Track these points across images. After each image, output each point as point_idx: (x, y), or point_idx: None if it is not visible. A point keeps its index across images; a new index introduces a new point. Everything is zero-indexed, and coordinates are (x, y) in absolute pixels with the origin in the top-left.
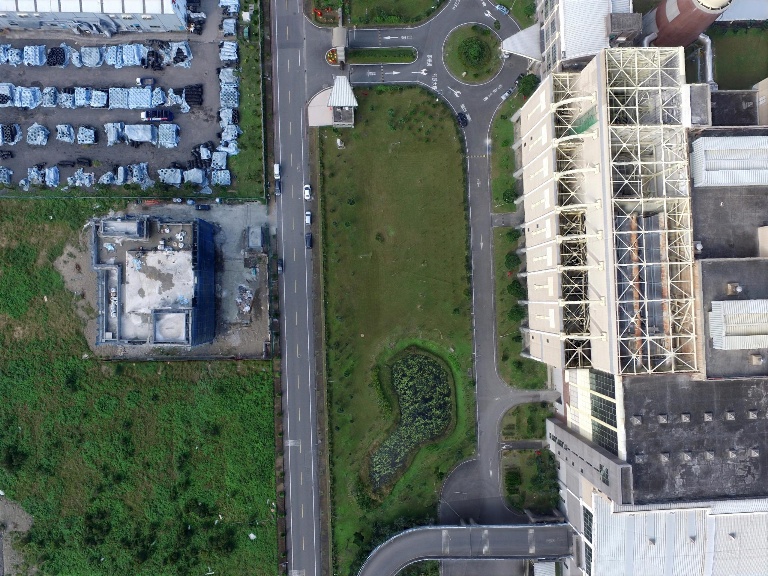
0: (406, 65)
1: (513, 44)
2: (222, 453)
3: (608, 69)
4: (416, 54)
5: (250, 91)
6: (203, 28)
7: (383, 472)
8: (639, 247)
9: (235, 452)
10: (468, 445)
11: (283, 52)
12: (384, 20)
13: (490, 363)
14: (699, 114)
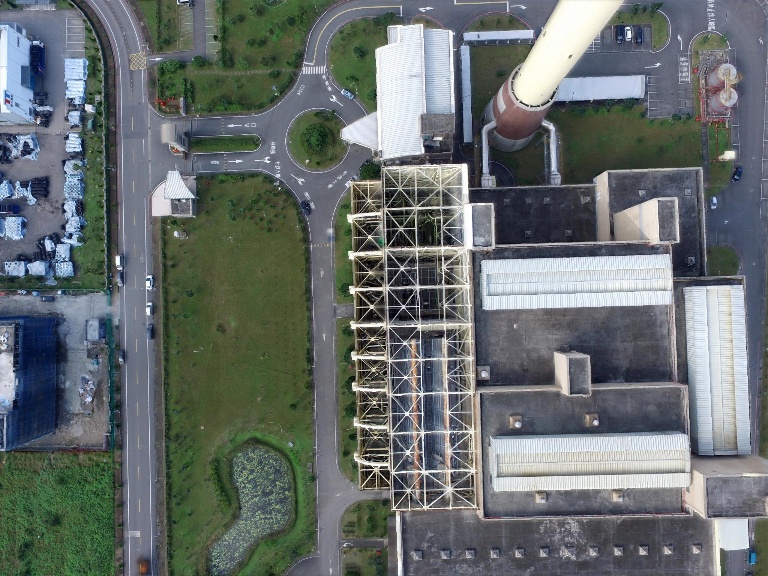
0: (249, 153)
1: (351, 133)
2: (63, 543)
3: (385, 189)
4: (259, 142)
5: (94, 182)
6: (50, 120)
7: (222, 566)
8: (416, 376)
9: (75, 542)
10: (307, 542)
11: (128, 142)
12: (226, 109)
13: (331, 458)
14: (483, 235)
